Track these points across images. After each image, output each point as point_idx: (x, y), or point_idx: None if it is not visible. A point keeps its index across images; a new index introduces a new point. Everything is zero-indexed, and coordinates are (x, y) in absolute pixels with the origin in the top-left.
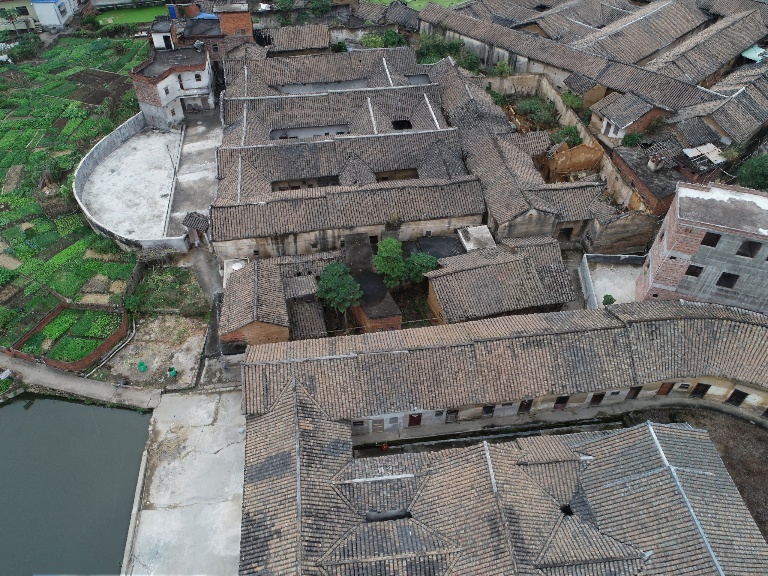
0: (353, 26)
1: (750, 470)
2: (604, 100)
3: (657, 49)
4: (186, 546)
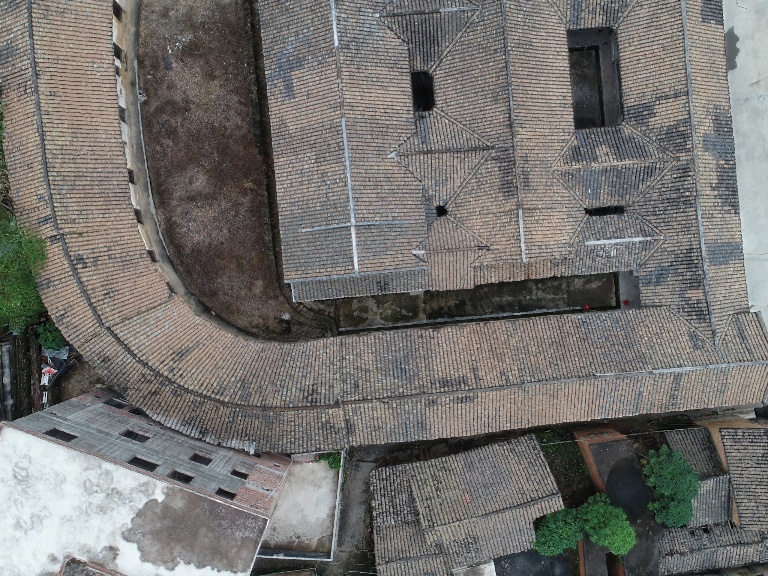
0: None
1: (239, 261)
2: None
3: None
4: (763, 216)
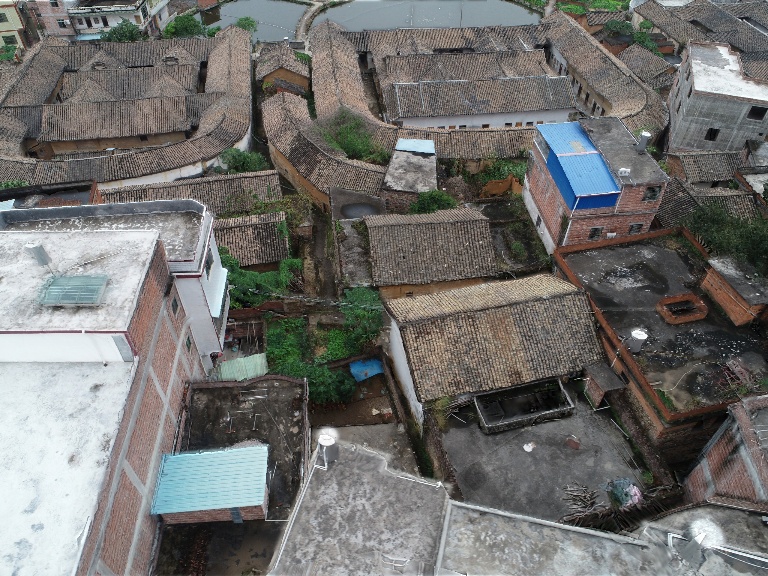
0: None
1: None
2: None
3: None
4: None
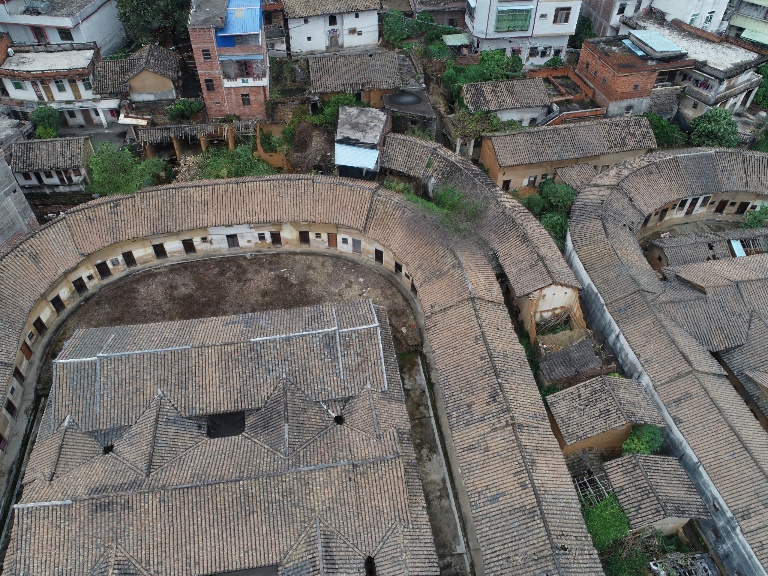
0: None
1: (119, 318)
2: None
3: None
4: None
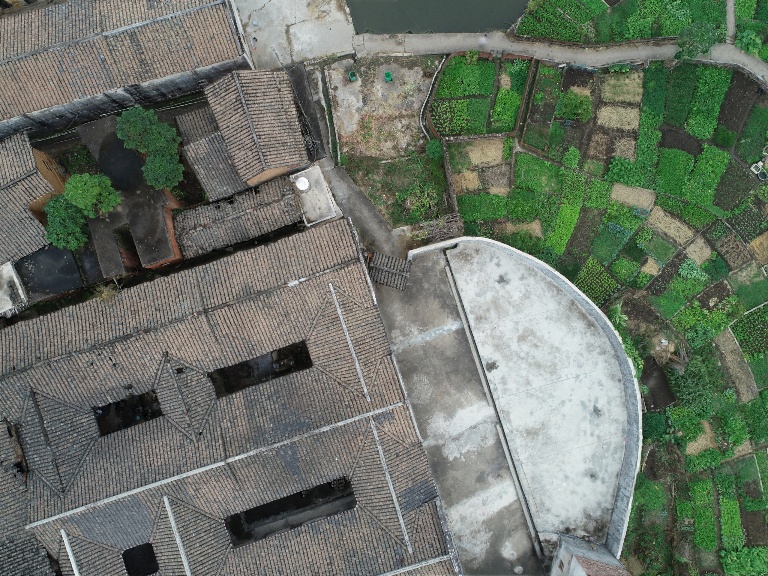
0: None
1: None
2: None
3: None
4: None
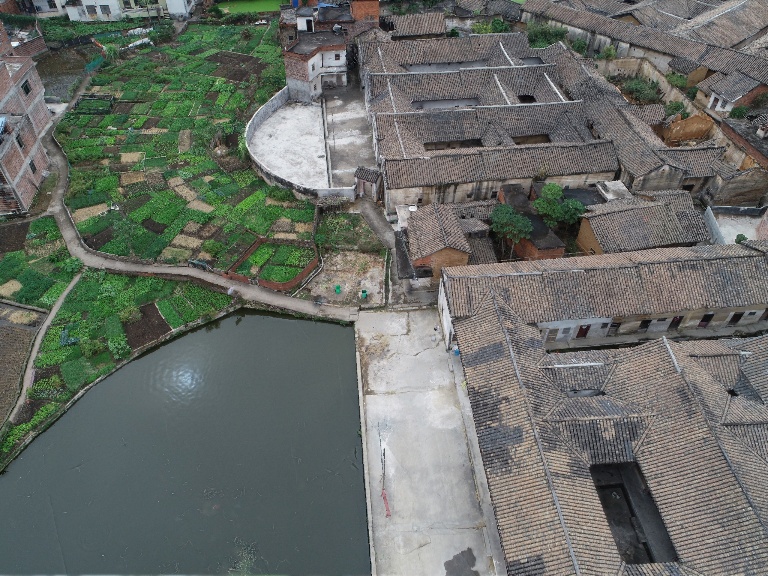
0: (460, 16)
1: None
2: (709, 79)
3: (744, 38)
4: (409, 421)
